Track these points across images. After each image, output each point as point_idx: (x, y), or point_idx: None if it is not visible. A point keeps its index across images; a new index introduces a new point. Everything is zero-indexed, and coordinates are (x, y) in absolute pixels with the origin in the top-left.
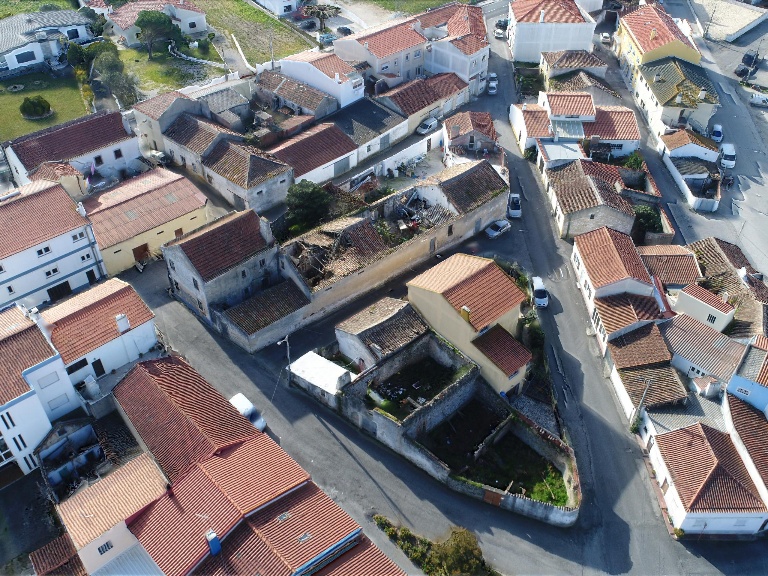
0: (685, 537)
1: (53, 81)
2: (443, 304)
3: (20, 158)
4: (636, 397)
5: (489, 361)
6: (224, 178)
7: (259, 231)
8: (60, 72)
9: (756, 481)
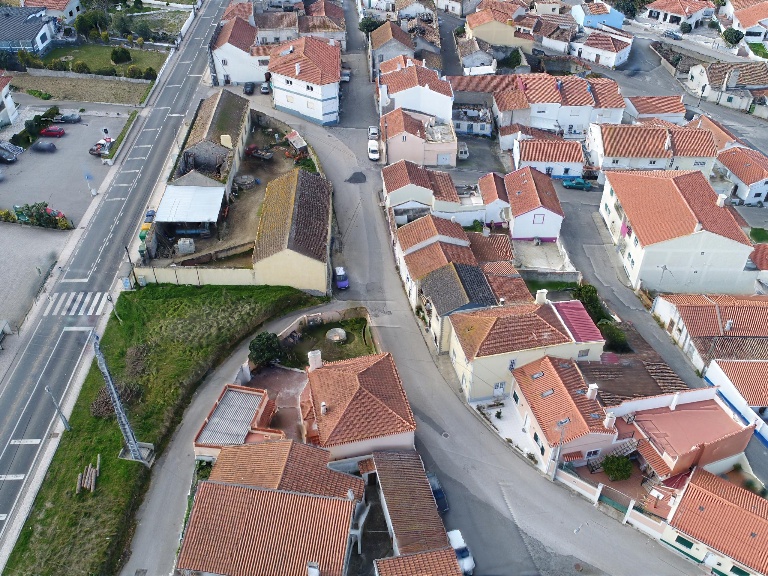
0: (616, 68)
1: (81, 48)
2: (497, 25)
3: (238, 48)
4: (564, 40)
5: (526, 40)
6: (323, 33)
7: (401, 29)
8: (77, 42)
9: (621, 39)
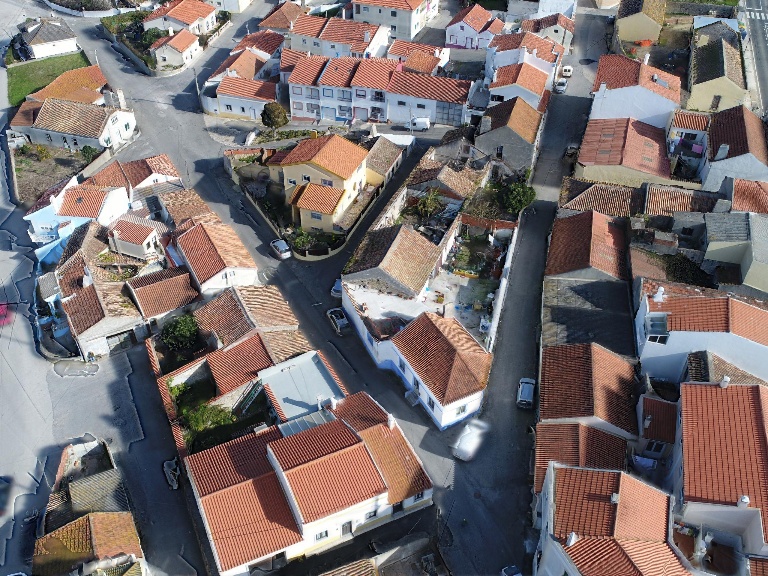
0: None
1: None
2: None
3: None
4: (193, 193)
5: None
6: None
7: None
8: None
9: None
